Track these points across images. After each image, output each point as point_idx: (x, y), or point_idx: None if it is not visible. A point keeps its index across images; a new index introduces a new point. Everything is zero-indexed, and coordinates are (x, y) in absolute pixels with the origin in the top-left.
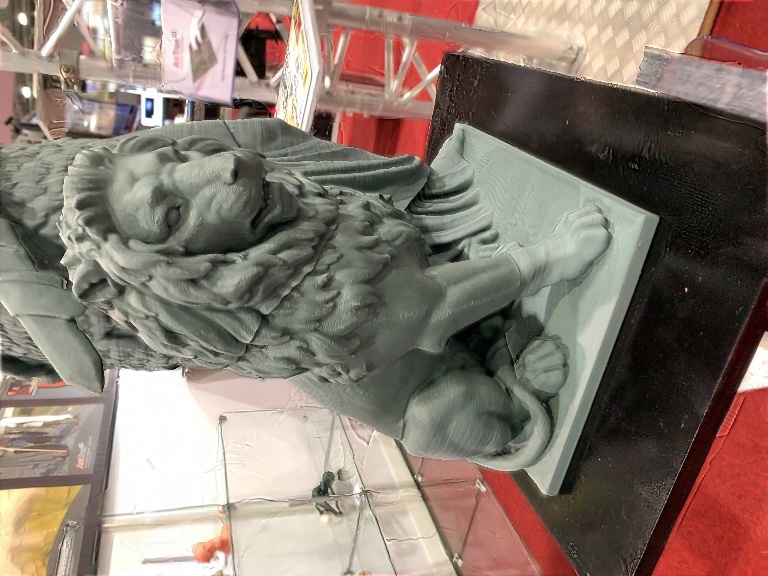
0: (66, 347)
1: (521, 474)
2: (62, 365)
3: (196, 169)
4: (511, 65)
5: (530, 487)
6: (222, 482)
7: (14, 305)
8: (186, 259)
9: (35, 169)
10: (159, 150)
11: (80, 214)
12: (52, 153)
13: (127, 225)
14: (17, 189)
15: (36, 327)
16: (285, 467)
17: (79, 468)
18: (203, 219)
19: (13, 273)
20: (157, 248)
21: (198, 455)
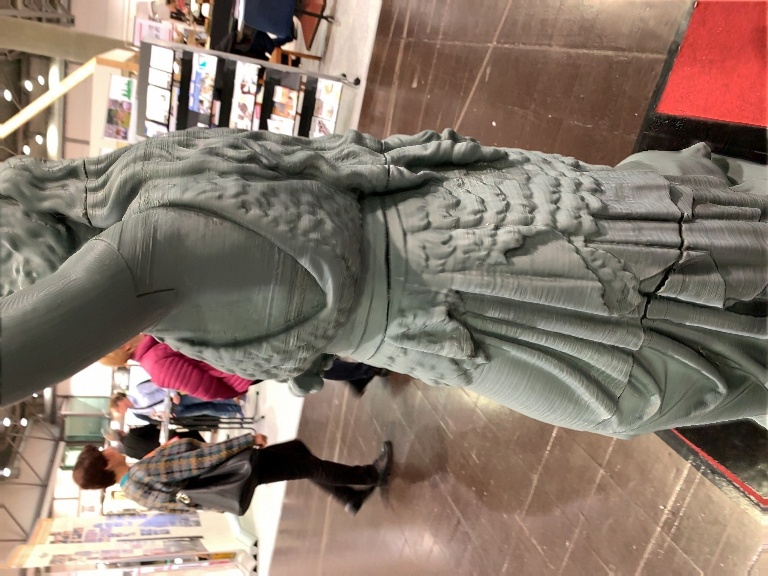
0: None
1: (734, 137)
2: None
3: None
4: (760, 494)
5: (722, 135)
6: None
7: None
8: None
9: None
10: None
11: None
12: None
13: None
14: None
15: None
16: None
17: None
18: None
19: None
20: None
21: None
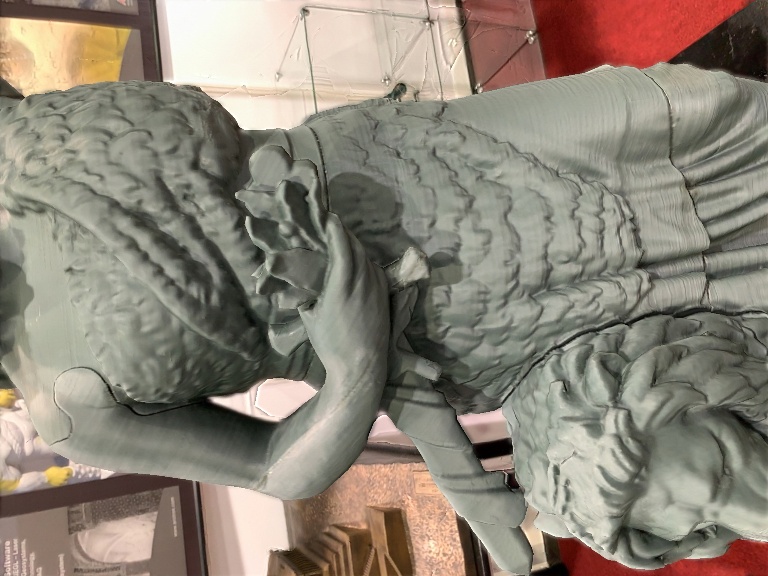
0: (509, 550)
1: None
2: (504, 562)
3: (754, 527)
4: None
5: None
6: (311, 109)
7: (464, 510)
8: (673, 550)
9: (472, 306)
10: (709, 466)
11: (606, 541)
12: (482, 256)
13: (635, 526)
14: (450, 338)
15: (483, 530)
16: (345, 44)
17: (121, 4)
18: (711, 525)
19: (465, 481)
20: (658, 554)
21: (254, 13)
